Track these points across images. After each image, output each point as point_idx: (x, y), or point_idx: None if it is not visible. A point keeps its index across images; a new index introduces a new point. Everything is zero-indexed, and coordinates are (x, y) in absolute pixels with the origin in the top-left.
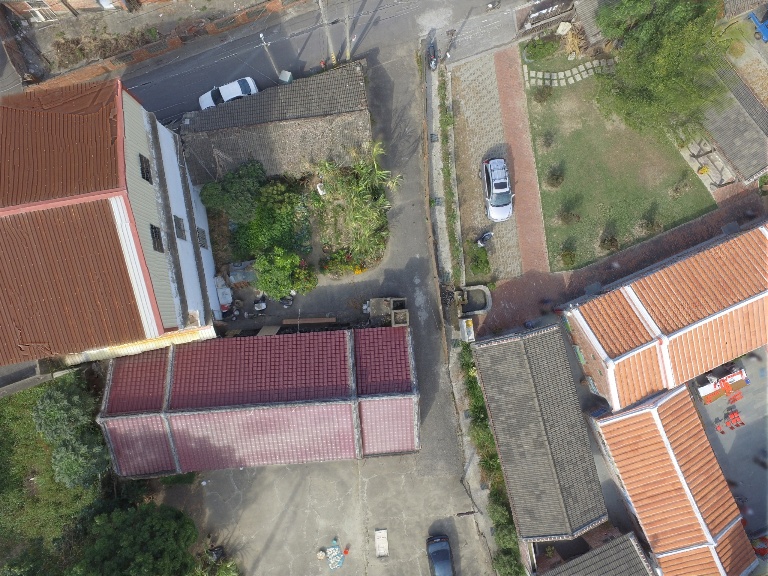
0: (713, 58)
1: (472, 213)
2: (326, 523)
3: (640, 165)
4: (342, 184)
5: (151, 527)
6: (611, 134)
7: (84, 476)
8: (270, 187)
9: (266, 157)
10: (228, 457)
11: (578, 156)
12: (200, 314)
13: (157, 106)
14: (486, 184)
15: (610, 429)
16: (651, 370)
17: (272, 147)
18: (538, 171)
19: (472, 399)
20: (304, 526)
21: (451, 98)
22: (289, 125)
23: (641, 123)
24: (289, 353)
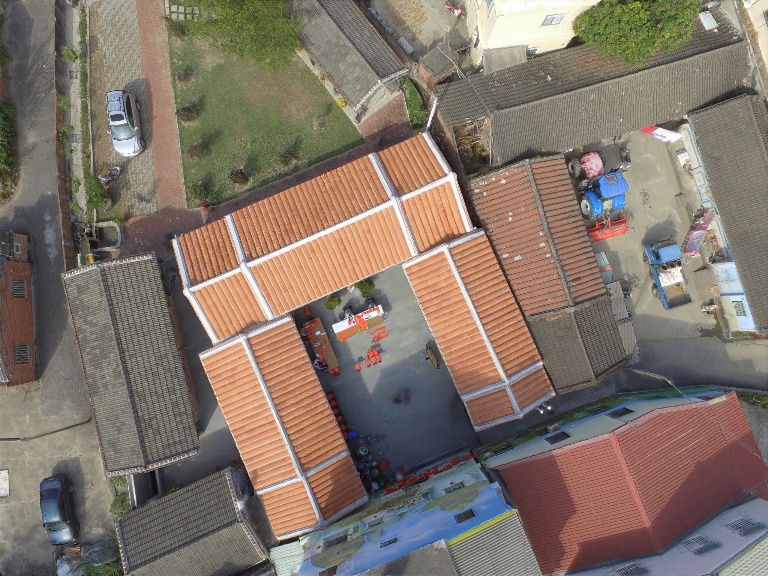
0: None
1: (107, 149)
2: None
3: (284, 99)
4: None
5: None
6: (254, 68)
7: None
8: None
9: None
10: None
11: (219, 91)
12: None
13: None
14: None
15: (210, 362)
16: (245, 300)
17: None
18: (177, 106)
19: None
20: None
21: (88, 34)
22: None
23: (242, 49)
24: None
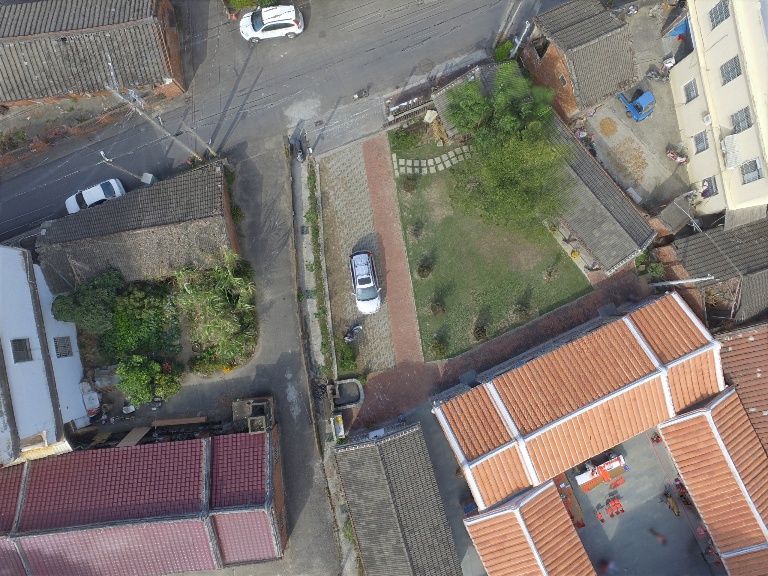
0: (538, 171)
1: (343, 305)
2: None
3: (513, 250)
4: (197, 291)
5: None
6: None
7: None
8: (124, 297)
9: (124, 264)
10: (84, 573)
11: (450, 243)
12: (48, 433)
13: (26, 209)
14: (352, 279)
15: (476, 528)
16: (513, 469)
17: (129, 254)
18: (409, 260)
19: None
20: None
21: (320, 190)
22: (143, 233)
23: (498, 218)
24: (144, 465)
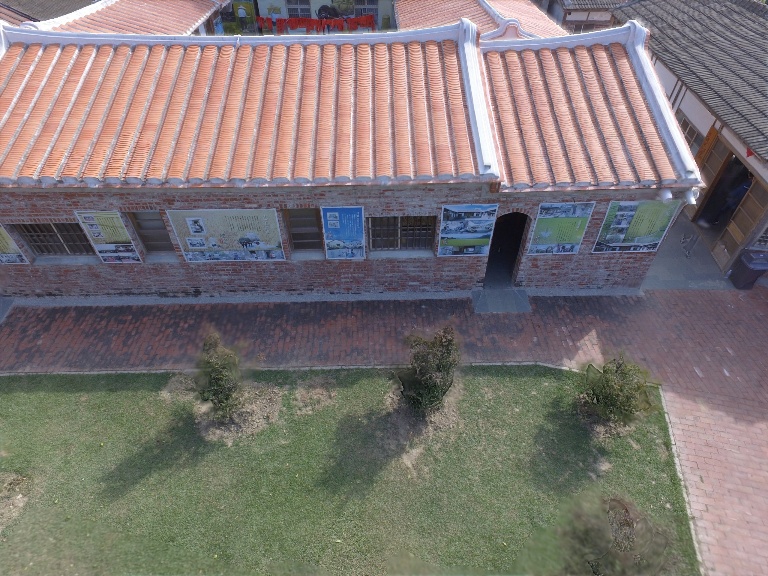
0: None
1: None
2: None
3: None
4: None
5: None
6: None
7: None
8: None
9: None
10: None
11: None
12: None
13: None
14: None
15: None
16: None
17: None
18: None
19: None
20: None
21: None
22: None
23: None
24: None
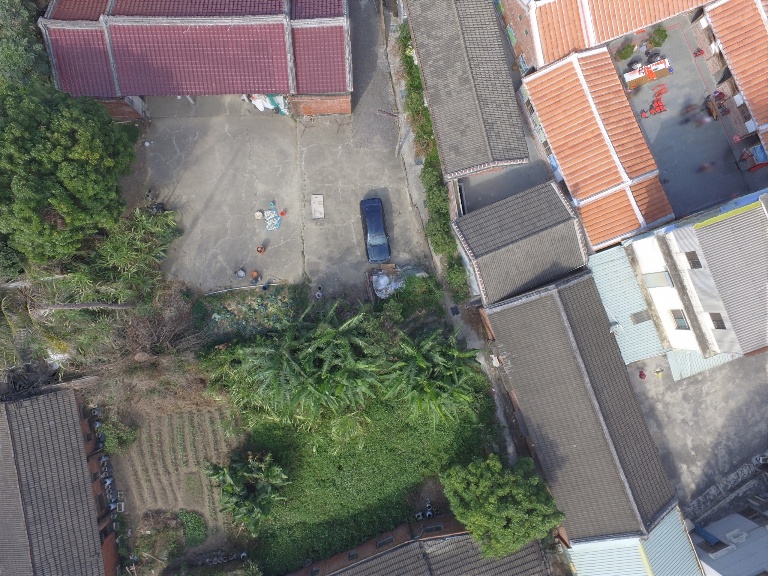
0: None
1: None
2: (264, 188)
3: None
4: None
5: (84, 101)
6: None
7: (23, 68)
8: None
9: None
10: (166, 81)
11: None
12: None
13: None
14: None
15: (534, 84)
16: (573, 24)
17: None
18: None
19: (408, 76)
20: (243, 189)
21: None
22: None
23: None
24: None
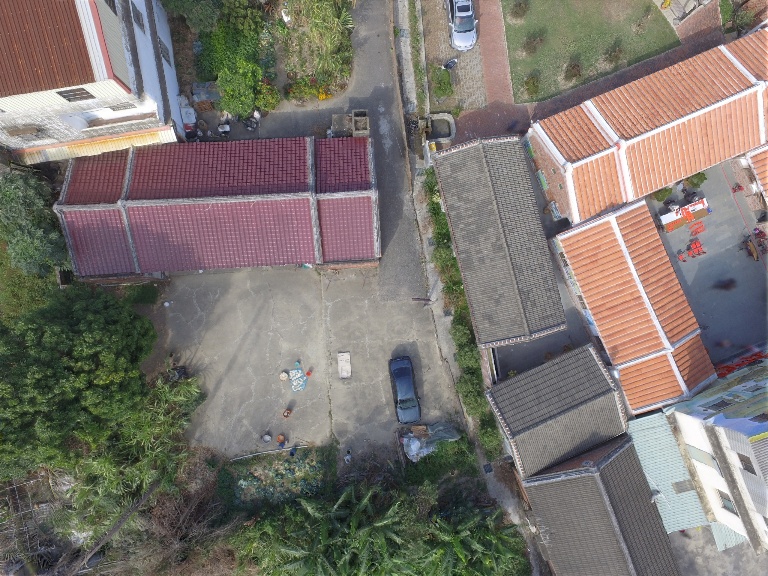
0: None
1: (437, 44)
2: (289, 346)
3: (604, 1)
4: None
5: (105, 302)
6: None
7: (40, 260)
8: None
9: None
10: (187, 257)
11: None
12: (159, 108)
13: None
14: (450, 10)
15: (570, 242)
16: (610, 180)
17: None
18: (503, 4)
19: (435, 225)
20: (267, 348)
21: None
22: None
23: None
24: (249, 156)
